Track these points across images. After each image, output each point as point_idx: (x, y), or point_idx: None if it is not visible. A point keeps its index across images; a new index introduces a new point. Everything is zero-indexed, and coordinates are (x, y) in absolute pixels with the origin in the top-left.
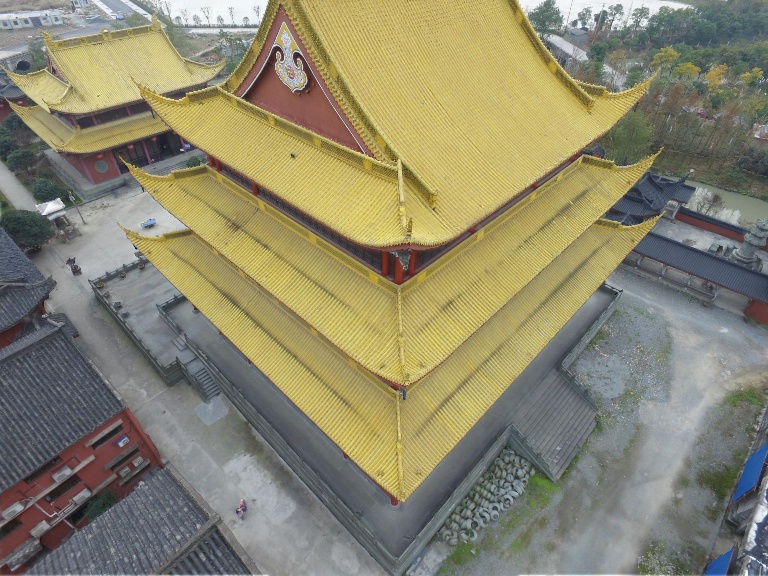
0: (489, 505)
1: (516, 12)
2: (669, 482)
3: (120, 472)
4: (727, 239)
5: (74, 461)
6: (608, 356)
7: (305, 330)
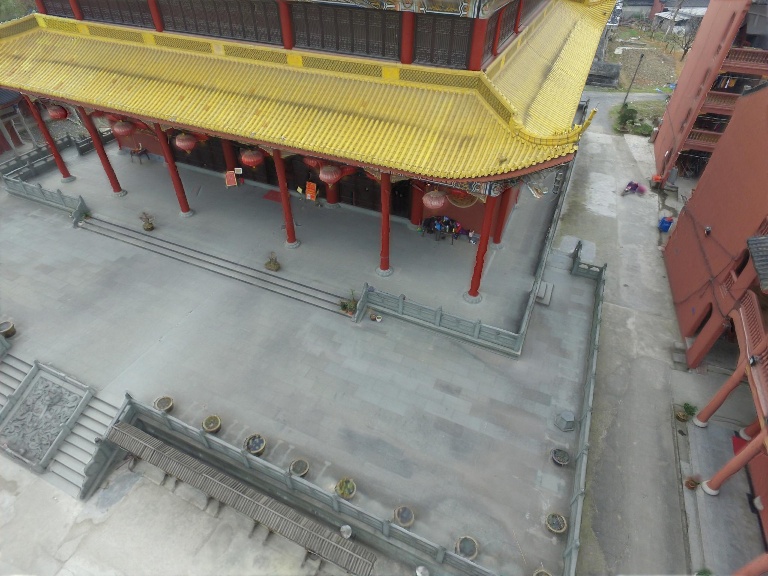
0: None
1: None
2: None
3: None
4: None
5: None
6: None
7: (543, 24)
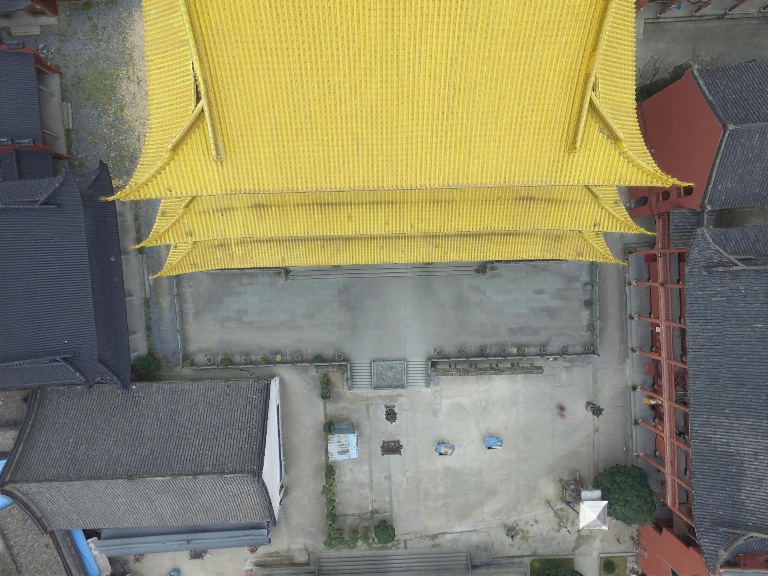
0: None
1: None
2: None
3: None
4: None
5: None
6: None
7: None
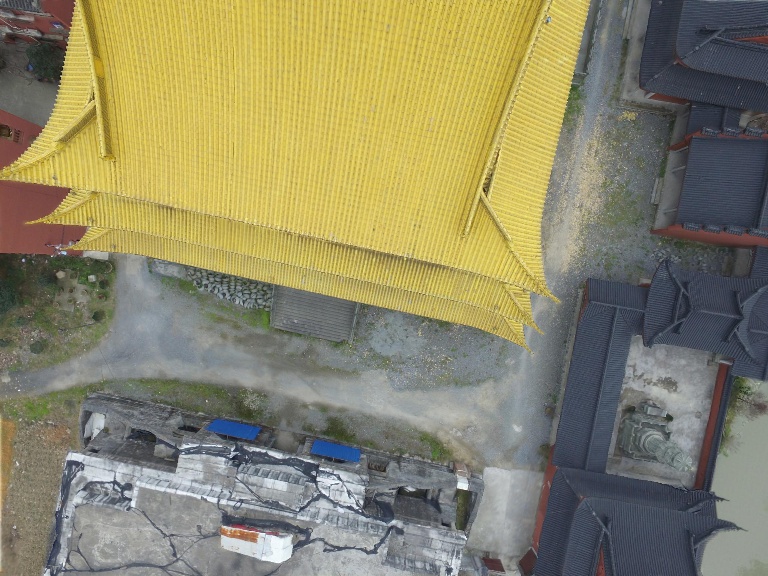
0: (225, 290)
1: (528, 38)
2: (317, 400)
3: (65, 38)
4: (703, 425)
5: (18, 11)
6: (420, 335)
7: None
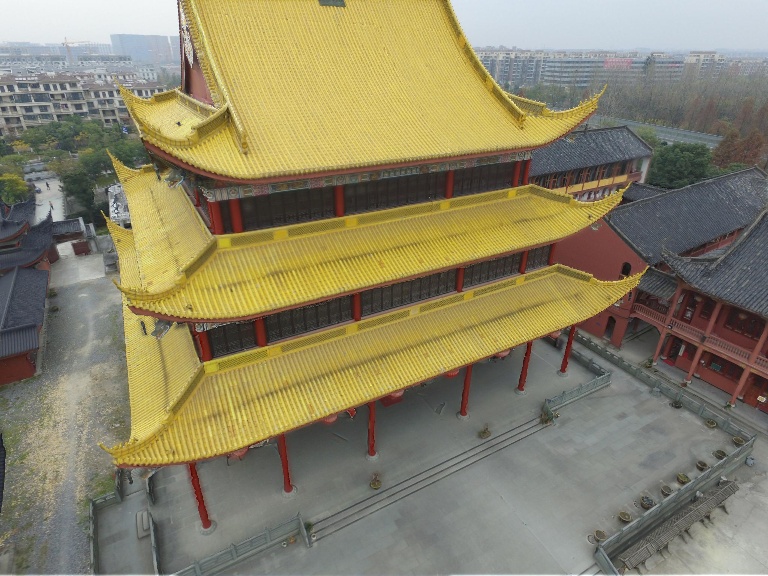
0: None
1: None
2: None
3: None
4: None
5: None
6: None
7: None
